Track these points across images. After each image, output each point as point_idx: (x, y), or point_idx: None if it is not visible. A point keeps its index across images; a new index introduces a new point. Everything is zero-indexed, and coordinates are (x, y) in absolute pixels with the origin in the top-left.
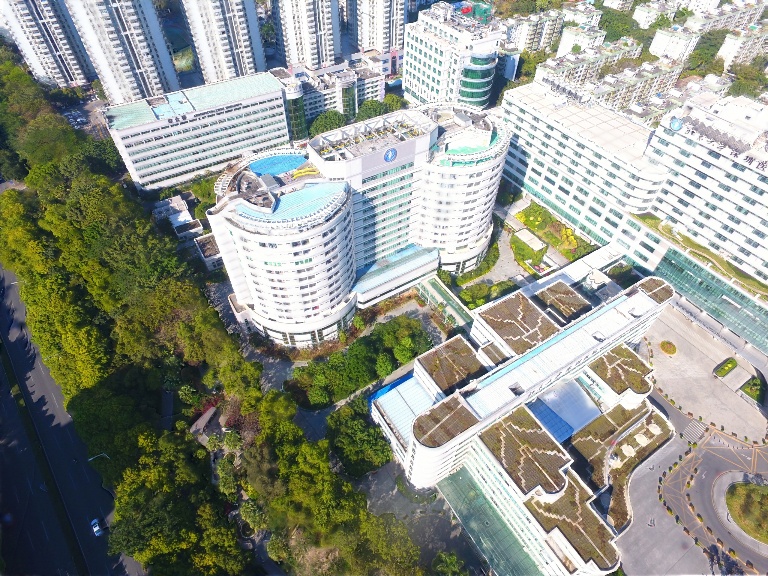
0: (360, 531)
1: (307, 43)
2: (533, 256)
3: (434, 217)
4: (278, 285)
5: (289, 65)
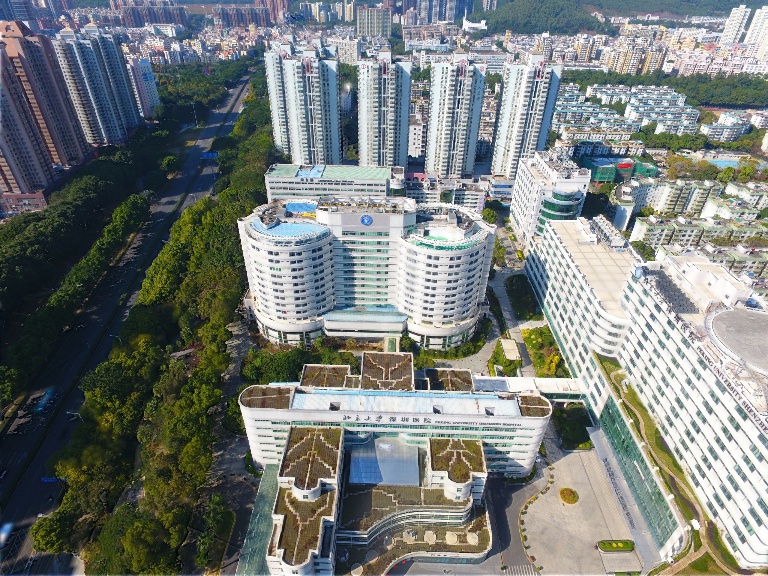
0: (185, 447)
1: (441, 157)
2: (503, 363)
3: (404, 285)
4: (261, 282)
5: (426, 171)
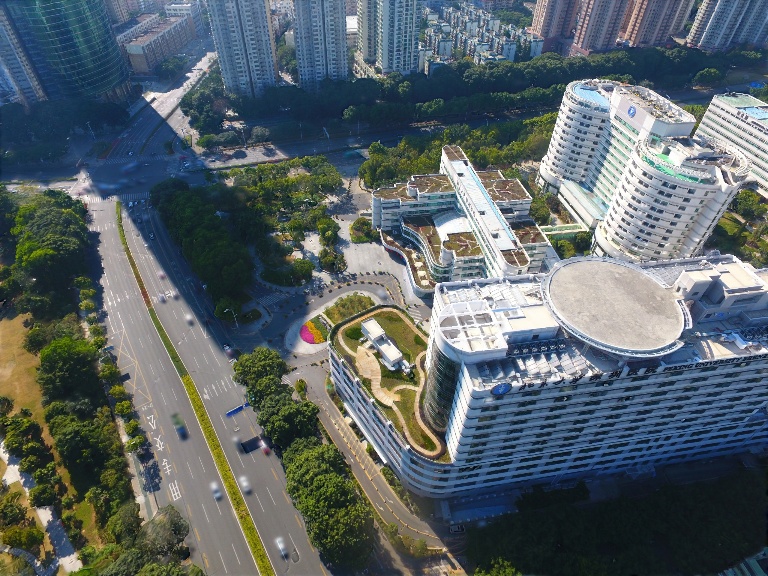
0: None
1: None
2: None
3: None
4: None
5: None
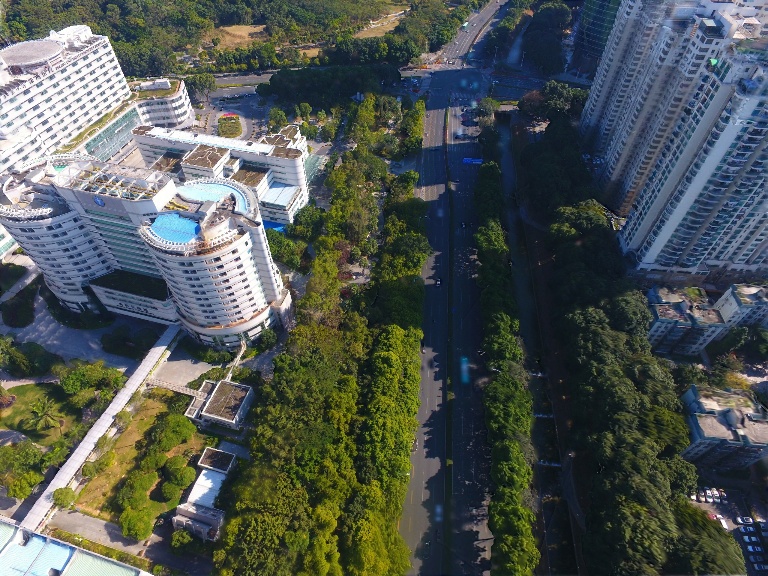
0: None
1: None
2: None
3: None
4: None
5: None
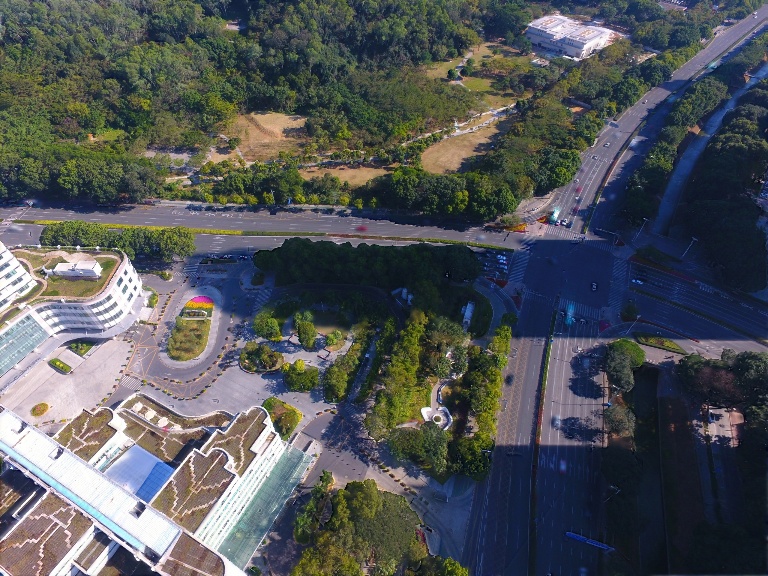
0: None
1: None
2: None
3: None
4: None
5: None
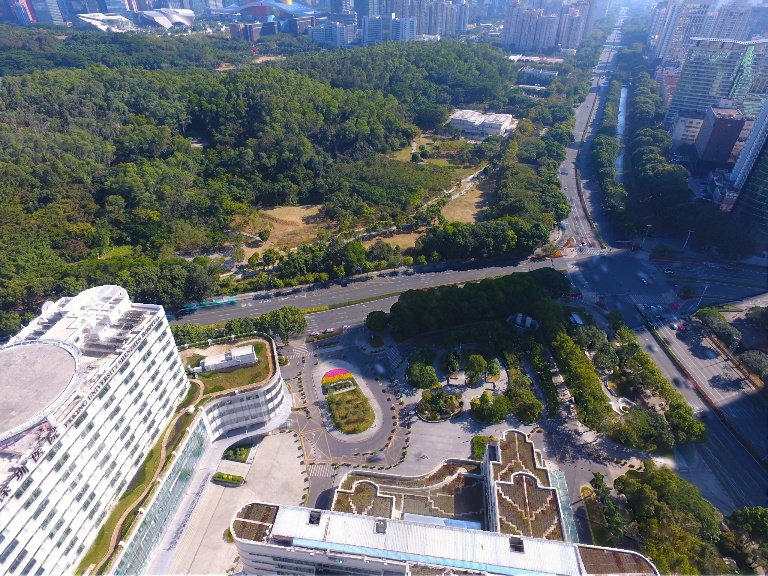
0: None
1: None
2: None
3: None
4: None
5: None
